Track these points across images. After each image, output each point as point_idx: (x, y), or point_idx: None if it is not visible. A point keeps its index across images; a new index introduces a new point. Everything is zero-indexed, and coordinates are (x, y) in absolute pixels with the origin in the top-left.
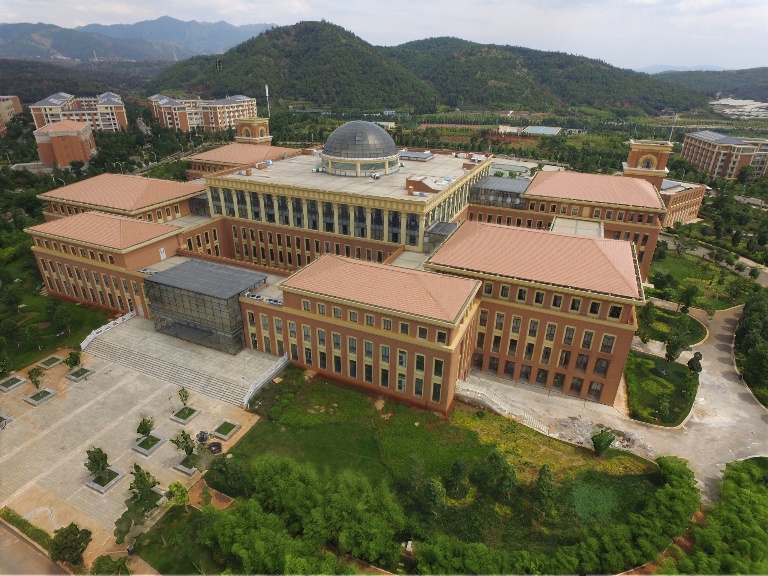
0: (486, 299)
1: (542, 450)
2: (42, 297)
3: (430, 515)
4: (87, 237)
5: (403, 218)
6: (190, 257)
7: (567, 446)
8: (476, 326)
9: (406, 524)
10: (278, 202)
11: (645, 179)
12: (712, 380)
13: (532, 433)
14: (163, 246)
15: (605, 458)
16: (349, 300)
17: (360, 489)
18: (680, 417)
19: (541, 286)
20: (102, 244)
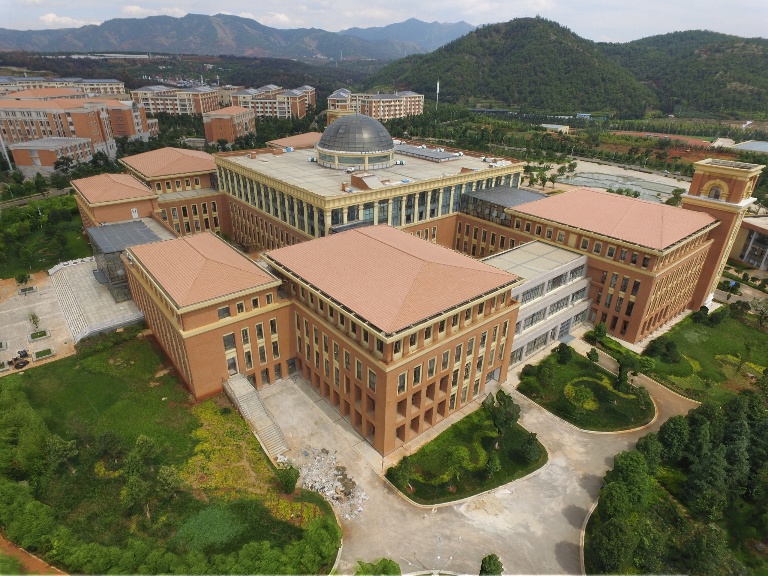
0: (295, 302)
1: (239, 464)
2: (80, 234)
3: (69, 471)
4: (87, 191)
5: (315, 212)
6: (154, 220)
7: (270, 471)
8: (294, 329)
9: (36, 468)
10: (250, 184)
11: (708, 213)
12: (556, 477)
13: (253, 446)
14: (136, 207)
15: (293, 498)
16: (147, 270)
17: (28, 425)
18: (444, 497)
19: (321, 298)
20: (88, 198)
